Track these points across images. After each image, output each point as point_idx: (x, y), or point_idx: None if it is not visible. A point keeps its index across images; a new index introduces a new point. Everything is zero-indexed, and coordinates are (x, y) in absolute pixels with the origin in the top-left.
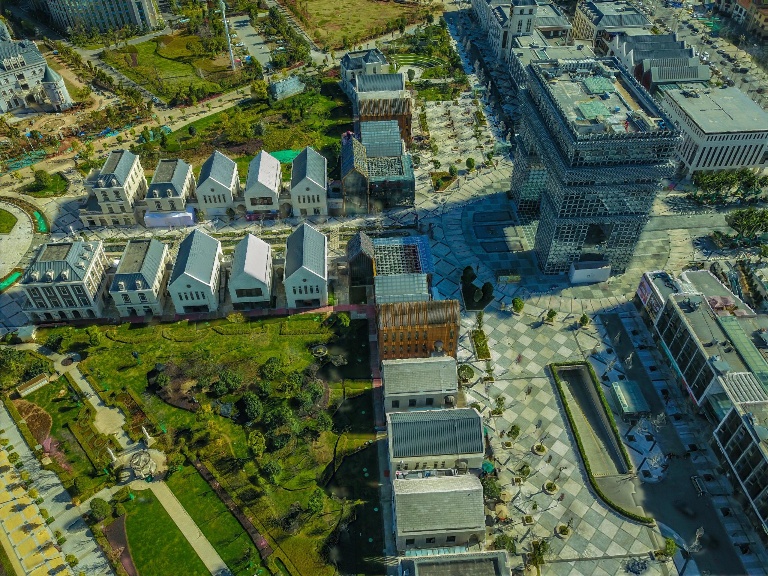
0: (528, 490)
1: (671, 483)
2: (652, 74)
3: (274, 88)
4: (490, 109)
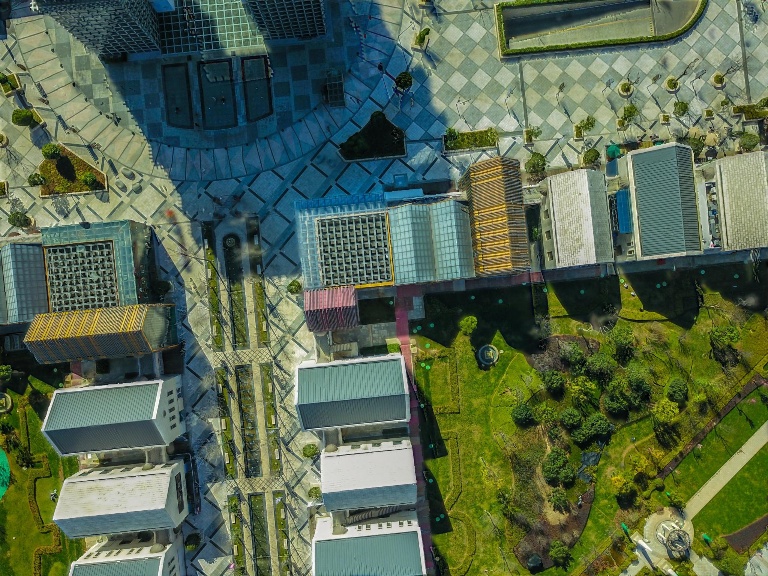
0: None
1: None
2: None
3: None
4: None
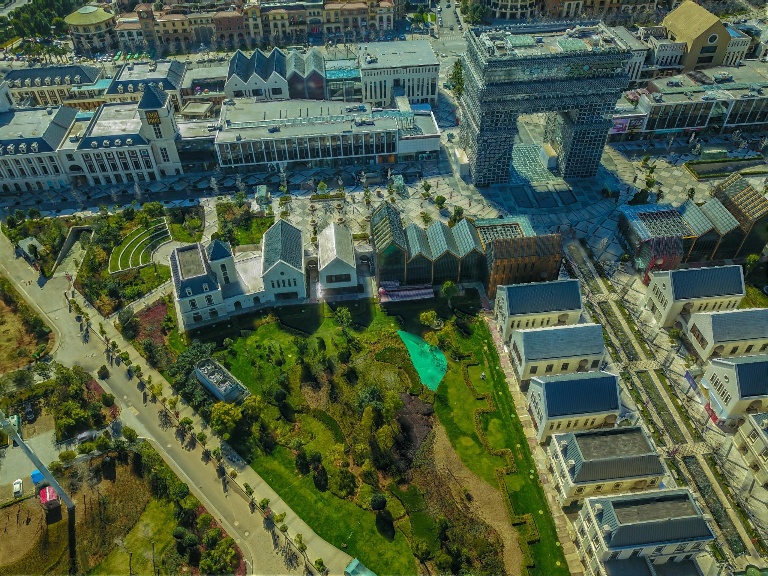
0: None
1: None
2: (319, 73)
3: (234, 391)
4: (302, 191)
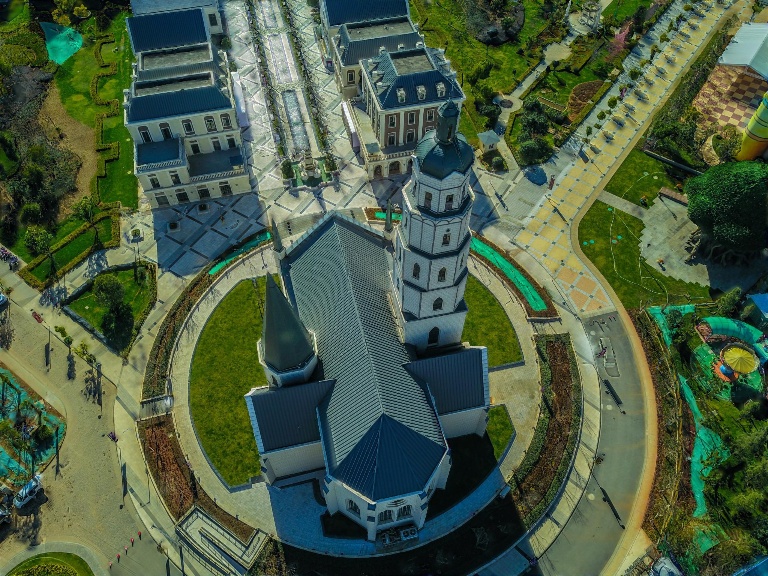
0: None
1: None
2: None
3: None
4: None
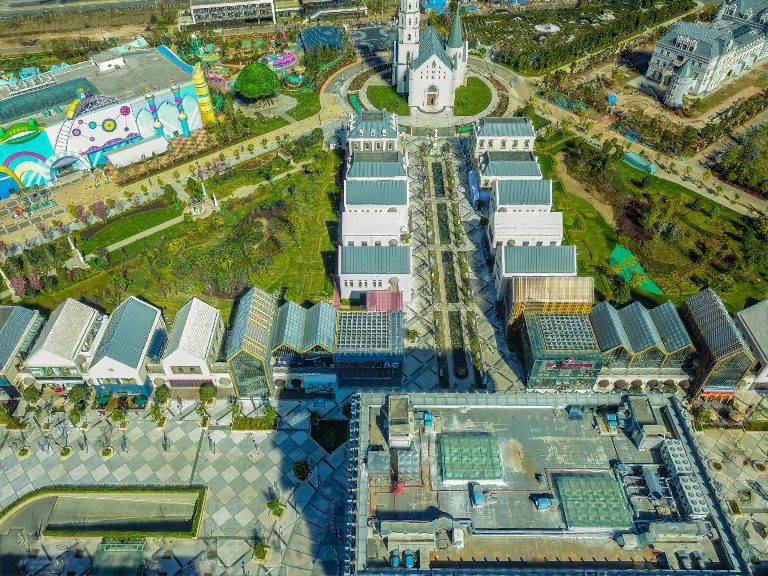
0: (73, 433)
1: (11, 575)
2: None
3: None
4: None
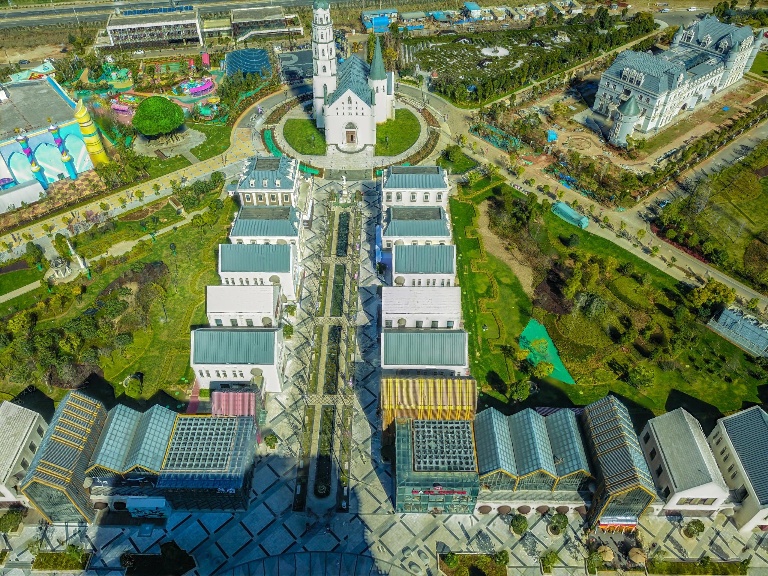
0: None
1: None
2: None
3: None
4: None
